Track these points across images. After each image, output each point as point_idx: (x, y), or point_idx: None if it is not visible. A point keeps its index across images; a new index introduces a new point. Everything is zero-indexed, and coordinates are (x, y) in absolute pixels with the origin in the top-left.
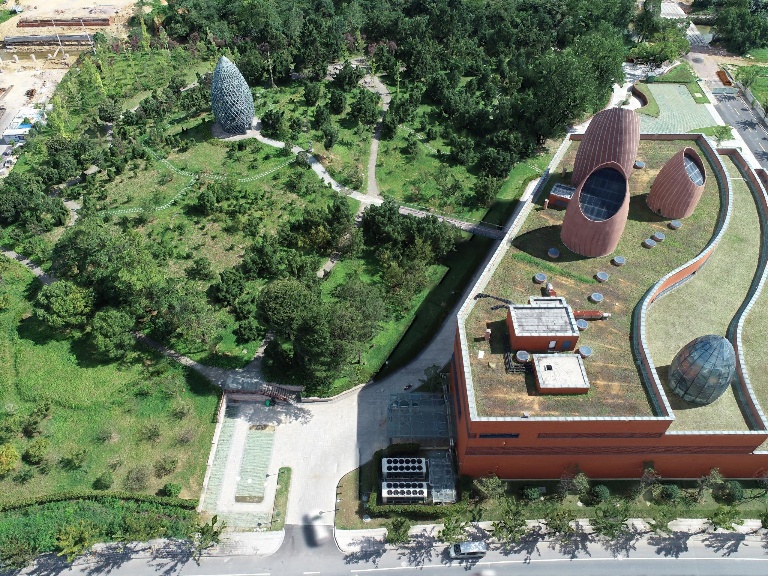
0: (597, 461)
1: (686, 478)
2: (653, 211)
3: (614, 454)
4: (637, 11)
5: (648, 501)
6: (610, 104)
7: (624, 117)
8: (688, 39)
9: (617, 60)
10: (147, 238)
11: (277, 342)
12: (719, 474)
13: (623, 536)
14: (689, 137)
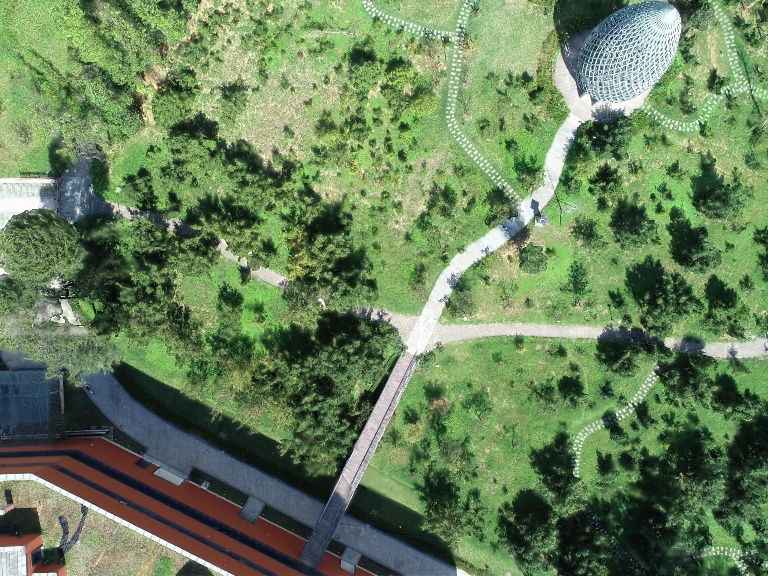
0: None
1: None
2: None
3: None
4: None
5: None
6: None
7: None
8: None
9: None
10: (299, 4)
11: None
12: None
13: None
14: None
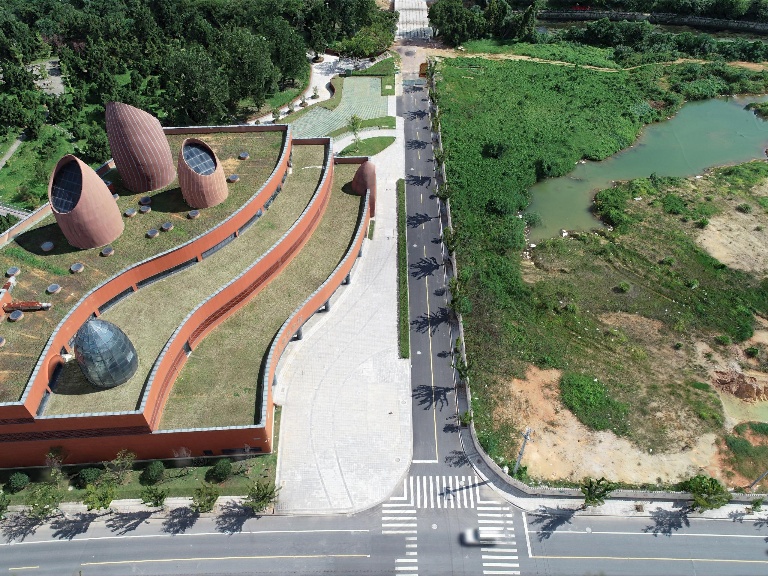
0: (7, 449)
1: (122, 461)
2: (184, 202)
3: (13, 441)
4: (359, 7)
5: (71, 486)
6: None
7: (118, 110)
8: (413, 33)
9: (257, 55)
10: None
11: None
12: (133, 455)
13: (29, 521)
14: (278, 128)
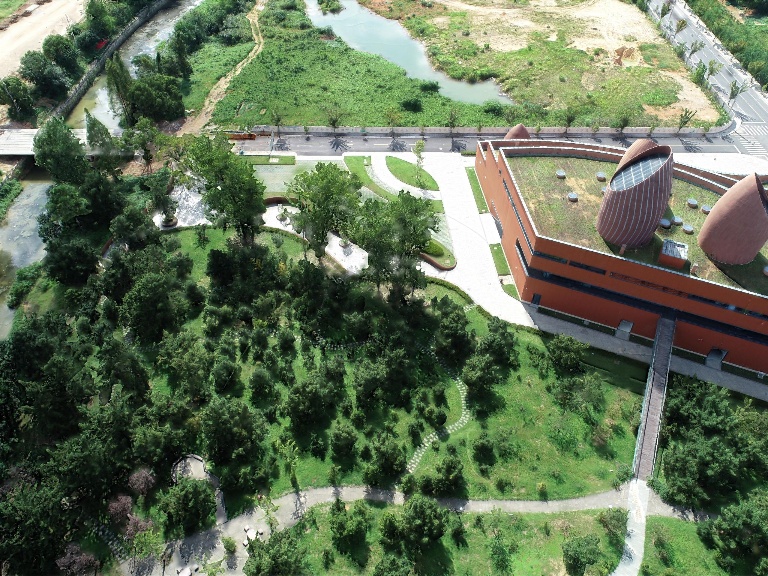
0: None
1: None
2: None
3: None
4: None
5: None
6: (284, 230)
7: None
8: None
9: None
10: None
11: None
12: None
13: None
14: None
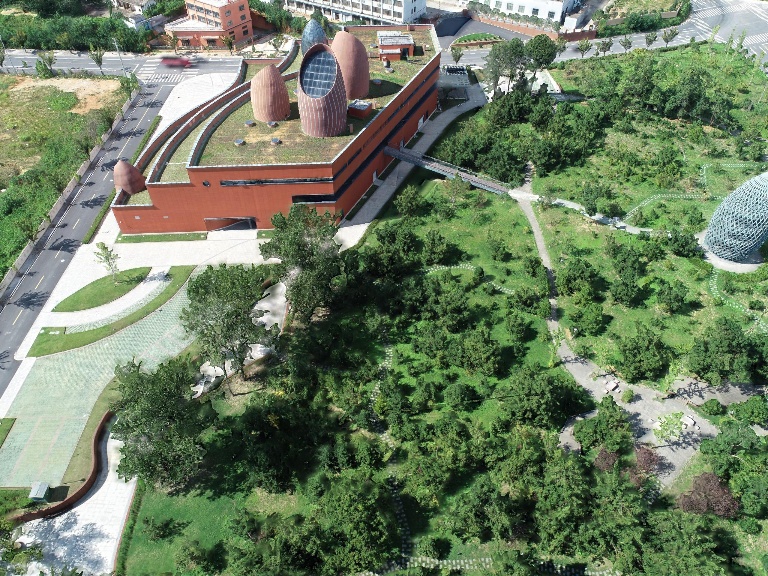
0: None
1: None
2: (290, 108)
3: None
4: None
5: None
6: None
7: (321, 48)
8: None
9: None
10: None
11: (543, 89)
12: None
13: None
14: (201, 170)
